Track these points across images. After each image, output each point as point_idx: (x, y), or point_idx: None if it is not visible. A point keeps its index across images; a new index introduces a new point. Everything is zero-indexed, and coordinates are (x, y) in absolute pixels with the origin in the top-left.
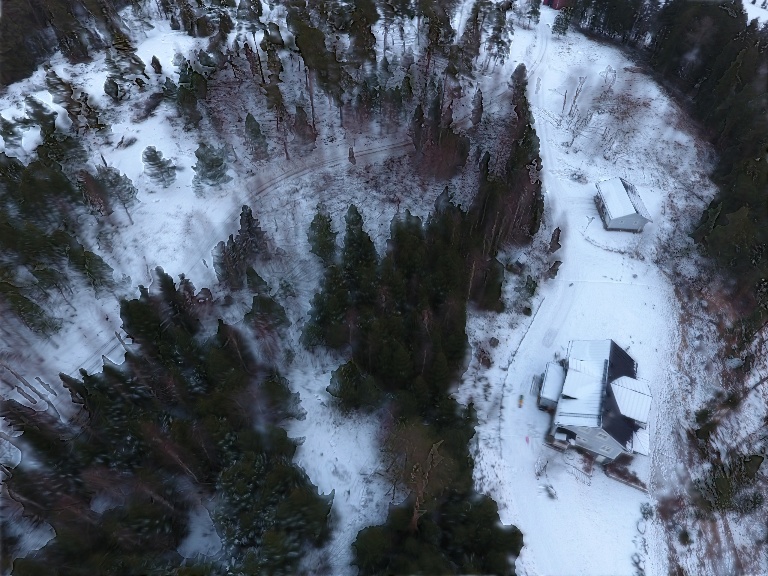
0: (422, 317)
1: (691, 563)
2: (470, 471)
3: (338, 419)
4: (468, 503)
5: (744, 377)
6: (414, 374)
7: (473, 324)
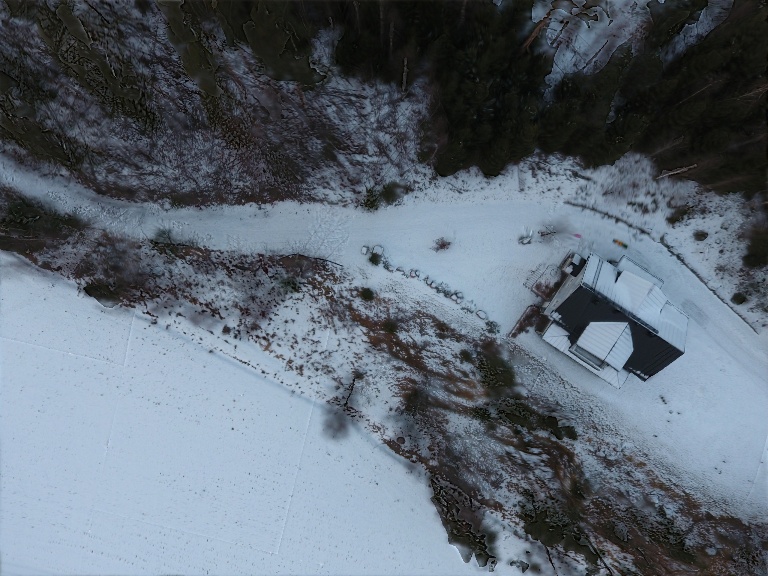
0: (763, 86)
1: (447, 352)
2: (563, 128)
3: (638, 16)
4: (535, 111)
5: (601, 543)
6: (680, 90)
7: (732, 217)
